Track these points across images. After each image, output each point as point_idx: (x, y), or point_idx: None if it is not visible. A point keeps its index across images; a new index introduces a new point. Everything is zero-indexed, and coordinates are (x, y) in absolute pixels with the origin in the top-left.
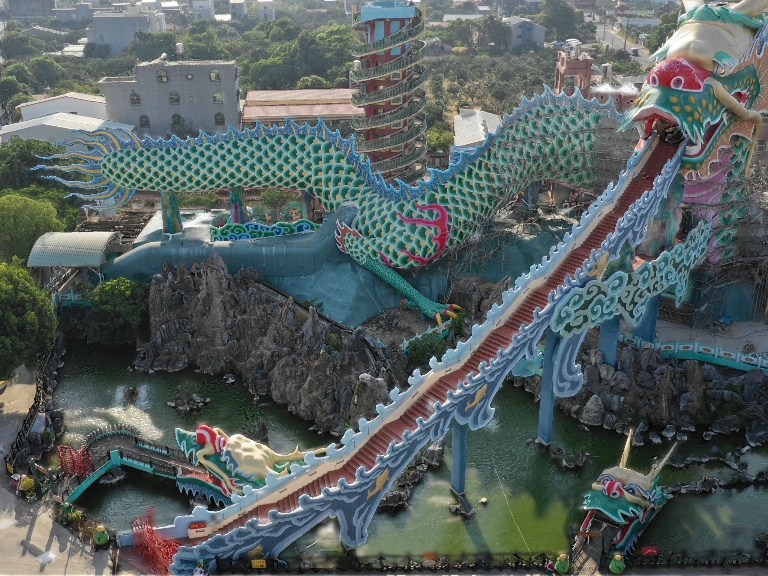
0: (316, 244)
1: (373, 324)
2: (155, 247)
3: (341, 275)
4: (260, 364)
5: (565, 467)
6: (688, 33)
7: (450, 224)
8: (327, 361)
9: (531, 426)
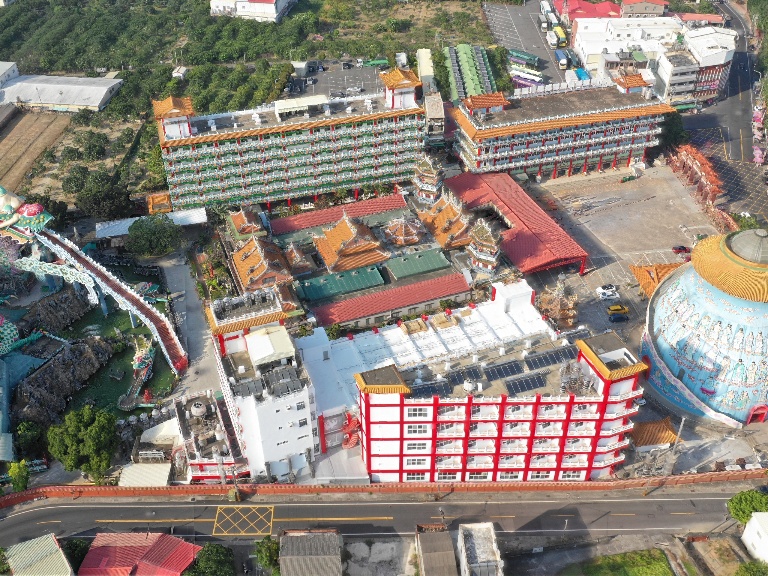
0: (1, 360)
1: (39, 356)
2: (3, 412)
3: (13, 360)
4: (70, 382)
5: (120, 309)
6: (11, 198)
7: (1, 315)
8: (89, 347)
9: (96, 318)
